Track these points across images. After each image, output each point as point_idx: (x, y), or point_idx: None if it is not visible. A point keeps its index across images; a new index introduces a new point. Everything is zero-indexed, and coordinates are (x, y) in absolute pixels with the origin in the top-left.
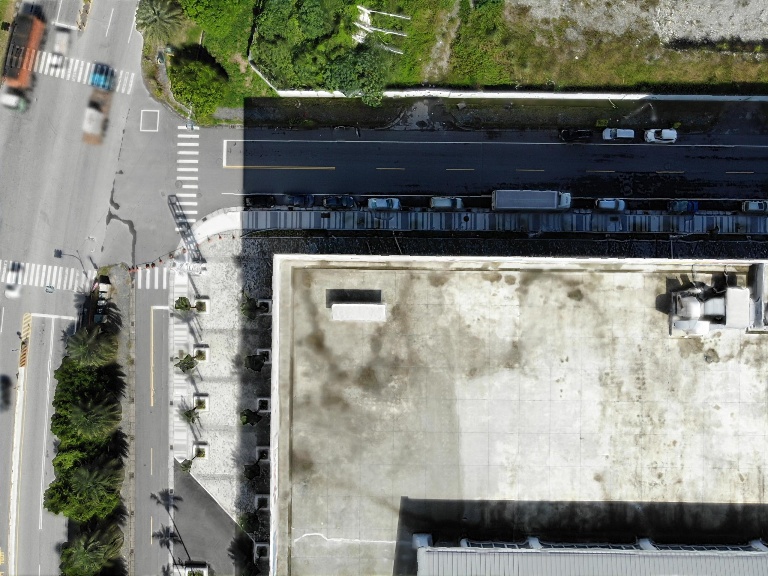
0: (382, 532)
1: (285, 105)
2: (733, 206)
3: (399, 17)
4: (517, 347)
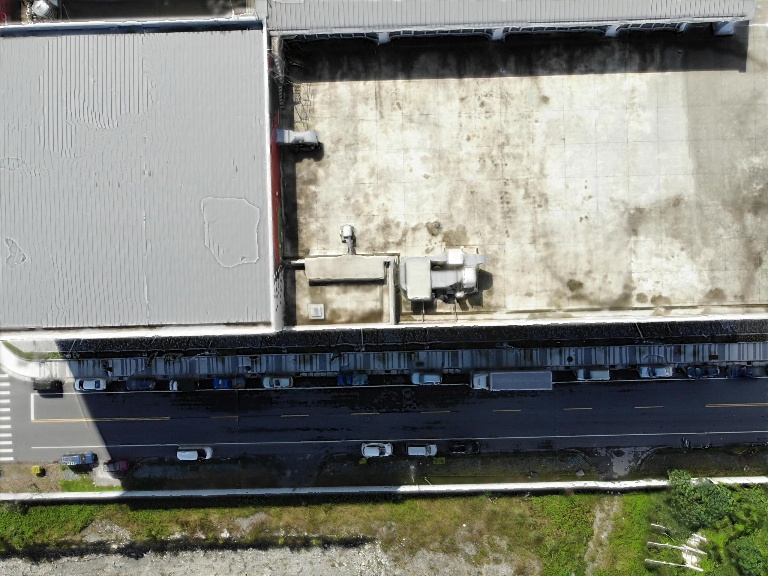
0: (765, 35)
1: (760, 468)
2: (301, 382)
3: (657, 561)
4: (633, 230)
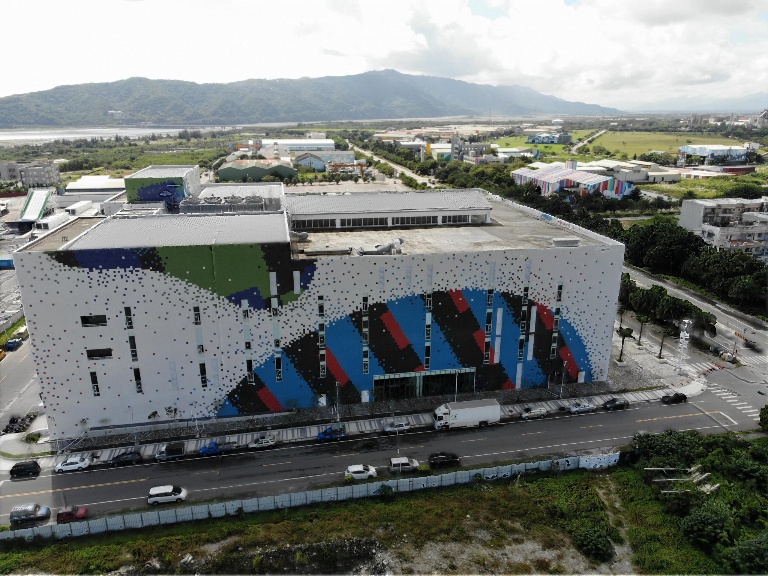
0: None
1: None
2: (283, 445)
3: (673, 491)
4: None
